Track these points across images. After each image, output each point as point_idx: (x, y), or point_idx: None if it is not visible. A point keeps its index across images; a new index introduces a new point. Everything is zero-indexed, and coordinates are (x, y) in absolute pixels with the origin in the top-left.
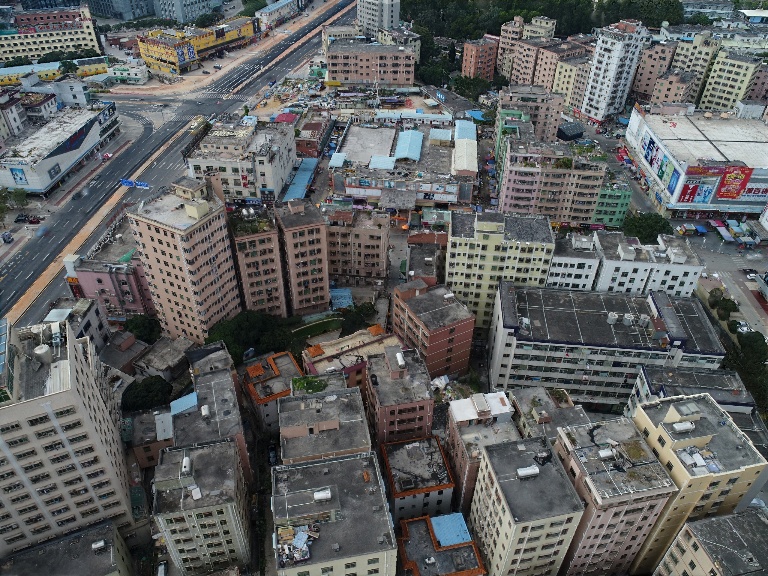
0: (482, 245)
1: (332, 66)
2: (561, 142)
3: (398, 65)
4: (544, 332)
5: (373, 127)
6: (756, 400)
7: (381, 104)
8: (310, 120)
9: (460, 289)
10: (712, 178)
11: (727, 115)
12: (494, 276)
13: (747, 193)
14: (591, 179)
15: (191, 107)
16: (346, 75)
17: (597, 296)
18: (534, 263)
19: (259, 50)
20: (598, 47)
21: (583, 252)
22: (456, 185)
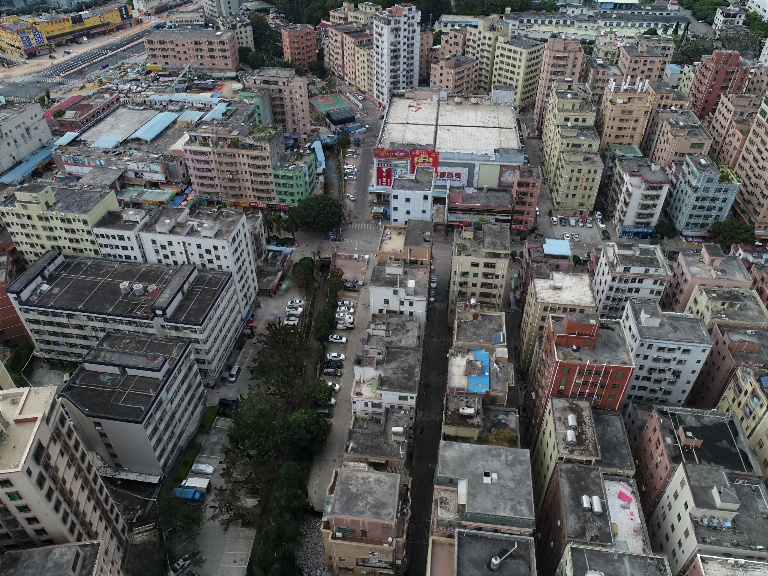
0: (26, 215)
1: (150, 51)
2: (332, 126)
3: (214, 50)
4: (53, 298)
5: (139, 109)
6: (260, 373)
7: (191, 88)
8: (90, 102)
9: (33, 258)
10: (401, 161)
11: (475, 100)
12: (53, 246)
13: (441, 177)
14: (259, 159)
15: (10, 89)
16: (166, 60)
17: (142, 268)
18: (78, 234)
19: (121, 36)
20: (374, 31)
21: (130, 224)
22: (158, 164)
